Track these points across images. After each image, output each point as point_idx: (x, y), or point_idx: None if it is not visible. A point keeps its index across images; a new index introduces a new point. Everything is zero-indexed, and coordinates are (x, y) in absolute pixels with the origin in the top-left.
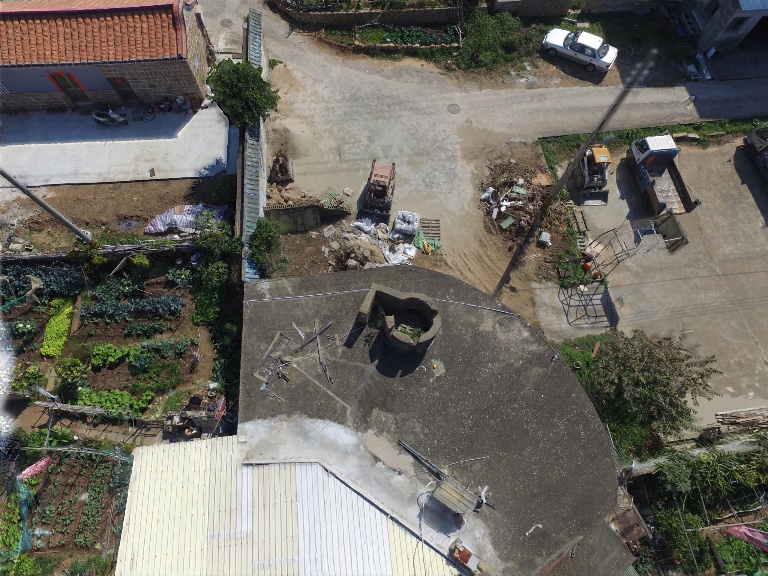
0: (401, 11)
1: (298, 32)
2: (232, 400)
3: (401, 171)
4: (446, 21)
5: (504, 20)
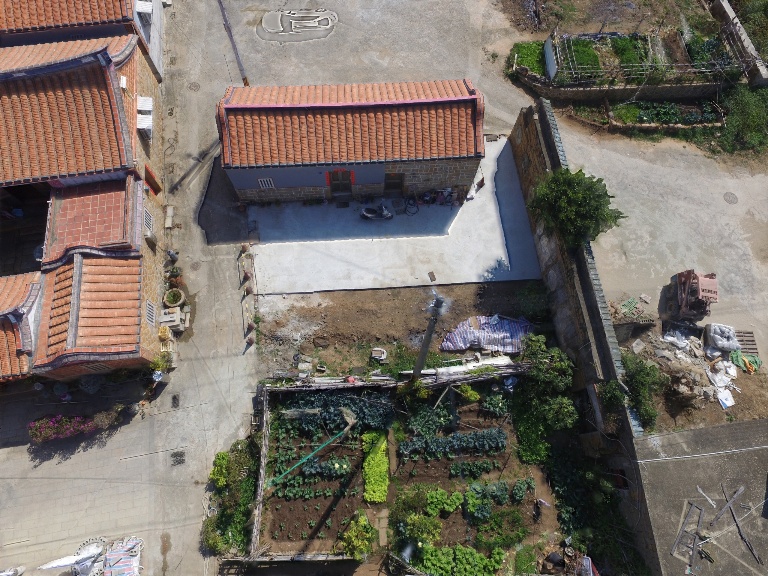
0: (657, 87)
1: None
2: (625, 573)
3: None
4: (698, 96)
5: (767, 97)
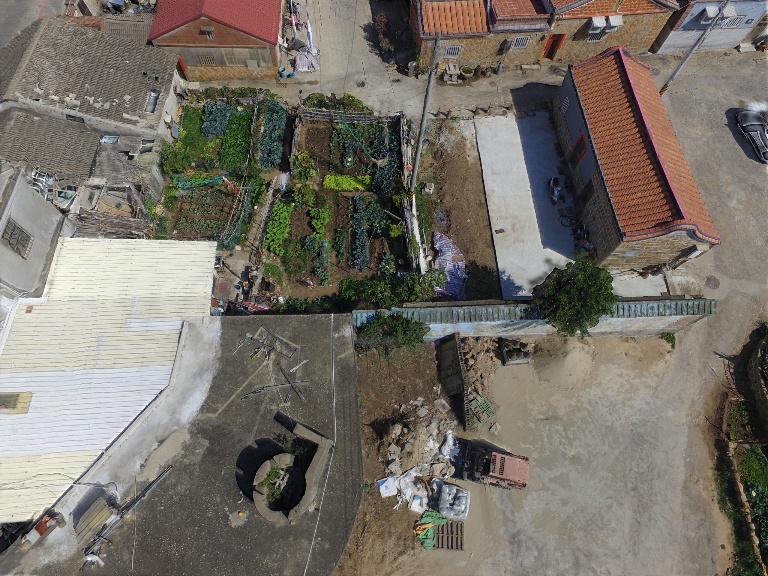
0: None
1: (729, 366)
2: None
3: (532, 500)
4: None
5: None
